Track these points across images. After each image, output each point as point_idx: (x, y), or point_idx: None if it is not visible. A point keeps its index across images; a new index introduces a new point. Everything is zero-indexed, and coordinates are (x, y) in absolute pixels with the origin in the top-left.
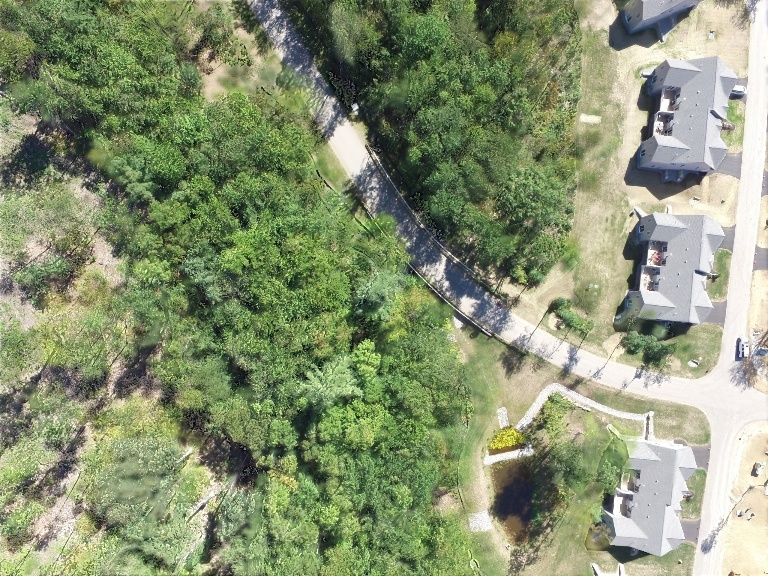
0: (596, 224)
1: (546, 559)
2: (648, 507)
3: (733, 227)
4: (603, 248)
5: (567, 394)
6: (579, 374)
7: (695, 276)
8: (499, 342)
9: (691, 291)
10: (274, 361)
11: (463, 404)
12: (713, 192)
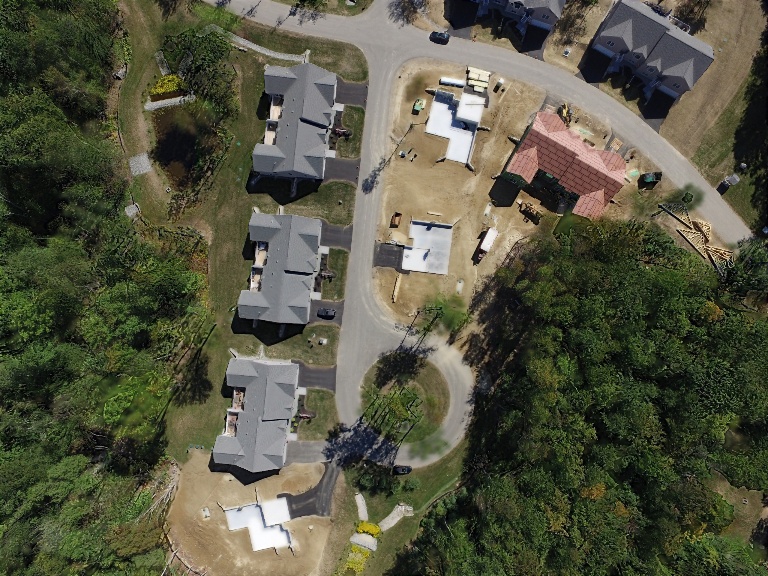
0: None
1: (207, 203)
2: (287, 127)
3: None
4: None
5: (224, 35)
6: (233, 12)
7: None
8: None
9: None
10: None
11: (121, 47)
12: None
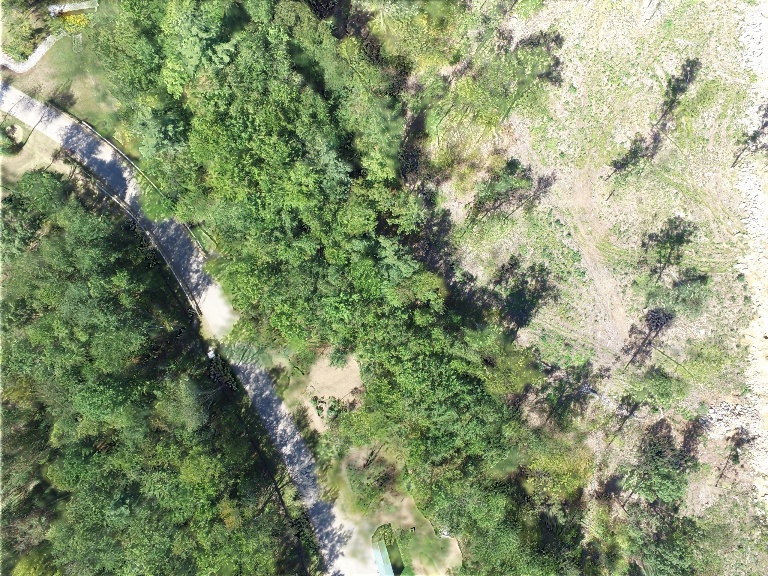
0: None
1: None
2: None
3: None
4: None
5: (8, 61)
6: None
7: None
8: (75, 115)
9: None
10: (266, 78)
11: None
12: None
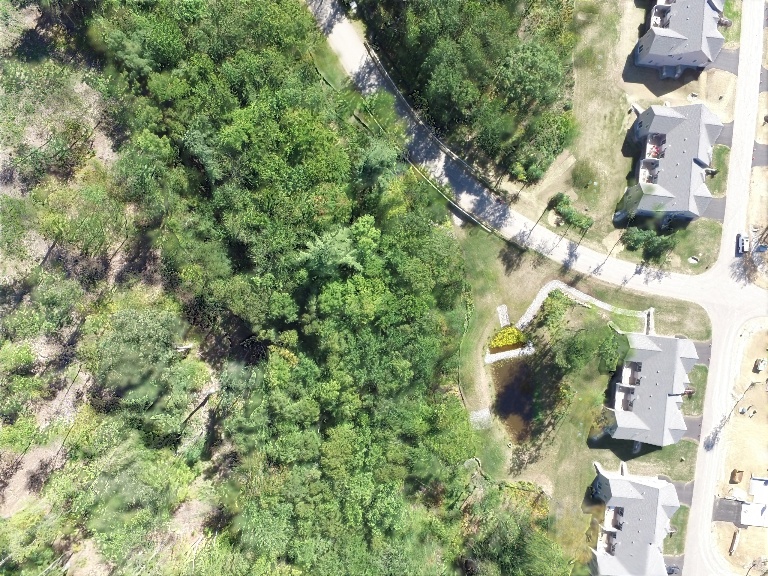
0: (594, 121)
1: (548, 457)
2: (650, 398)
3: (731, 123)
4: (602, 145)
5: (567, 291)
6: (579, 270)
7: (694, 165)
8: (499, 238)
9: (690, 180)
10: (274, 234)
11: (463, 301)
12: (711, 88)
